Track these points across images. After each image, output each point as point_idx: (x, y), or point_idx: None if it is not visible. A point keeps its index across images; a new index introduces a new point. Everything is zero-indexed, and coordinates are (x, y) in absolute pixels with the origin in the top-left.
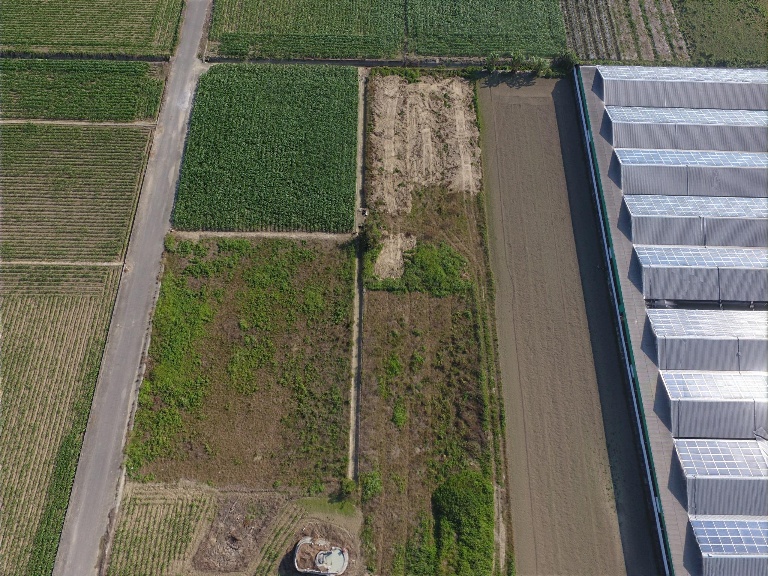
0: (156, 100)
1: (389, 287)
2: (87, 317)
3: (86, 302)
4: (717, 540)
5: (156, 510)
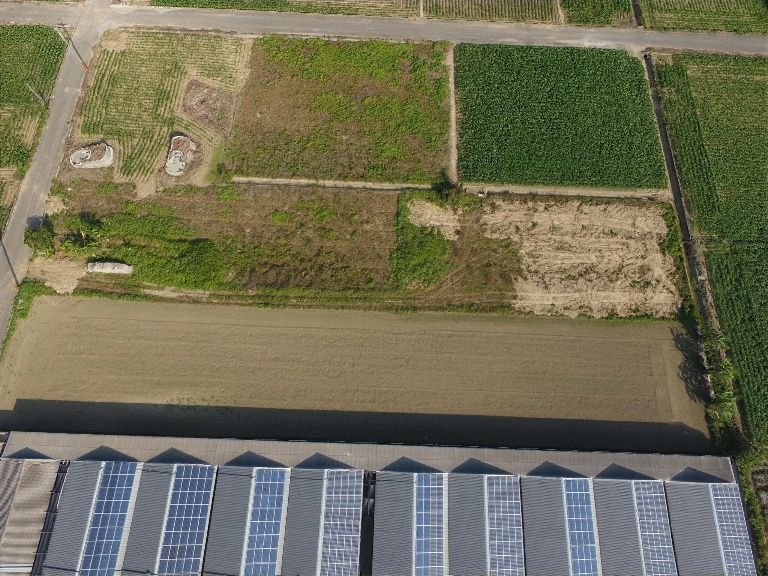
0: (588, 21)
1: (400, 212)
2: (377, 3)
3: (389, 0)
4: (113, 483)
5: (232, 58)
